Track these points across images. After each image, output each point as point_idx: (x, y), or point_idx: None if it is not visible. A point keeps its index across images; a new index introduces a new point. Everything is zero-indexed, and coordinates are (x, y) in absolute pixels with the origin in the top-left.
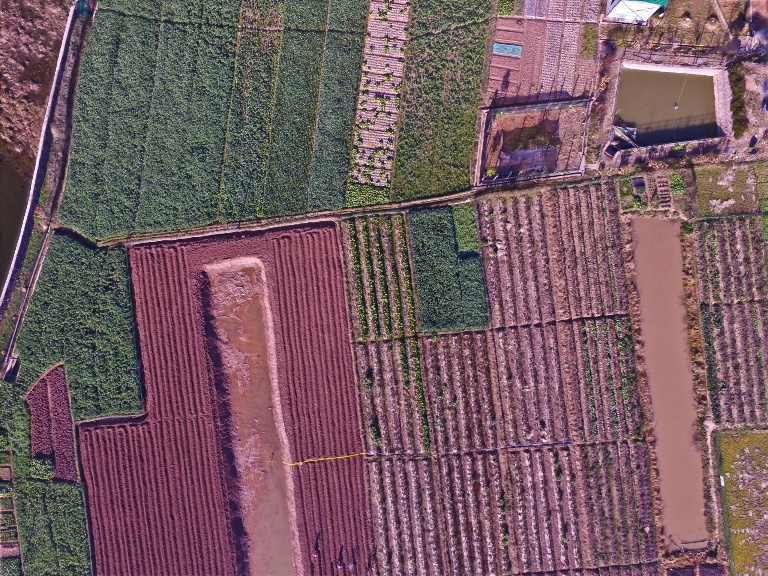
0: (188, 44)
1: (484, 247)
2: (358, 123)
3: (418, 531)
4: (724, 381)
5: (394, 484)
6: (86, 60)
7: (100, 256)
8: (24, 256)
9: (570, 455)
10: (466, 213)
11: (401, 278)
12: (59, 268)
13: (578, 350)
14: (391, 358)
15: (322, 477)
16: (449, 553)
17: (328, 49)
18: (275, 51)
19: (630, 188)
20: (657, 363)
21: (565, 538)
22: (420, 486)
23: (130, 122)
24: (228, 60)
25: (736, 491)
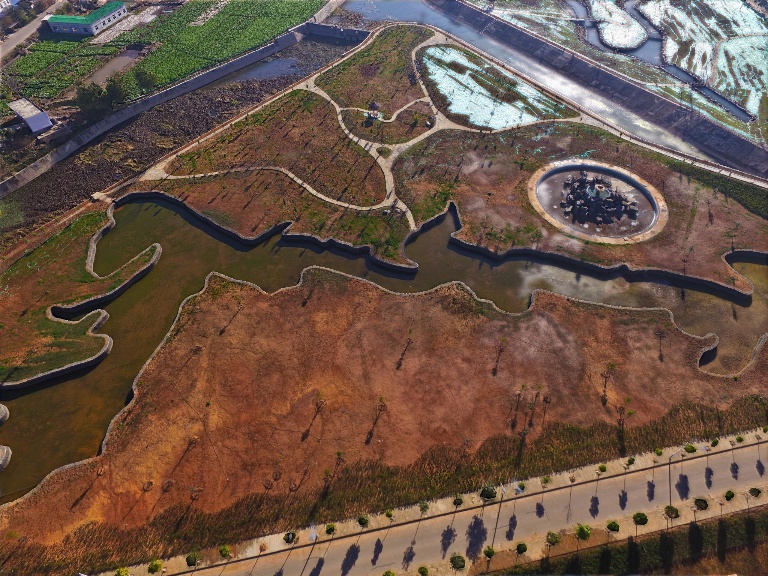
0: None
1: None
2: None
3: None
4: None
5: None
6: None
7: None
8: None
9: None
10: None
11: None
12: None
13: None
14: None
15: None
16: None
17: None
18: None
19: None
20: None
21: None
22: None
23: (302, 4)
24: None
25: None
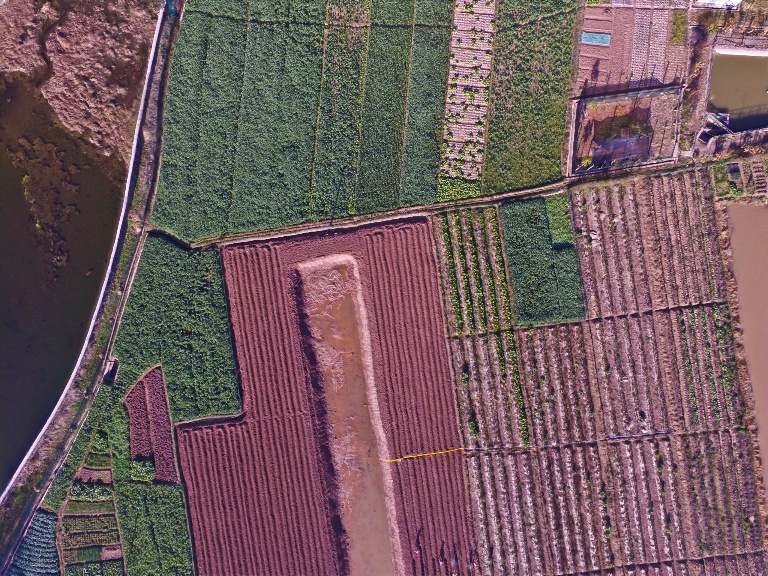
0: (276, 43)
1: (578, 238)
2: (447, 117)
3: (519, 525)
4: None
5: (493, 478)
6: (175, 62)
7: (194, 257)
8: (119, 259)
9: (670, 445)
10: (559, 204)
11: (495, 271)
12: (154, 270)
13: (676, 339)
14: (487, 352)
15: (421, 473)
16: (551, 547)
17: (416, 44)
18: (362, 47)
19: (725, 174)
20: (757, 350)
21: (669, 529)
22: (519, 480)
23: (221, 123)
24: (316, 58)
25: None
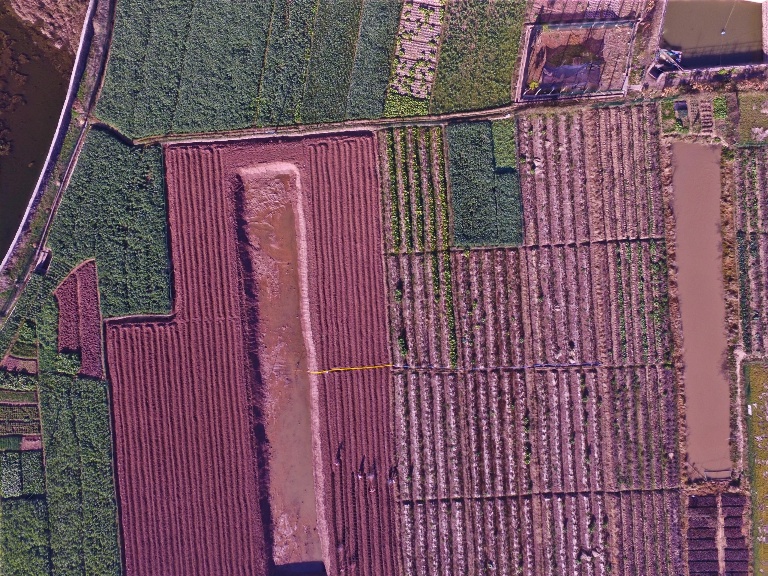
0: None
1: (522, 164)
2: (401, 33)
3: (441, 445)
4: (757, 310)
5: (419, 398)
6: None
7: (136, 153)
8: (60, 150)
9: (597, 377)
10: (505, 129)
11: (436, 191)
12: (94, 163)
13: (611, 272)
14: (422, 271)
15: (347, 387)
16: (471, 469)
17: None
18: None
19: (672, 111)
20: (690, 289)
21: (588, 460)
22: (445, 401)
23: (172, 20)
24: None
25: (763, 422)
